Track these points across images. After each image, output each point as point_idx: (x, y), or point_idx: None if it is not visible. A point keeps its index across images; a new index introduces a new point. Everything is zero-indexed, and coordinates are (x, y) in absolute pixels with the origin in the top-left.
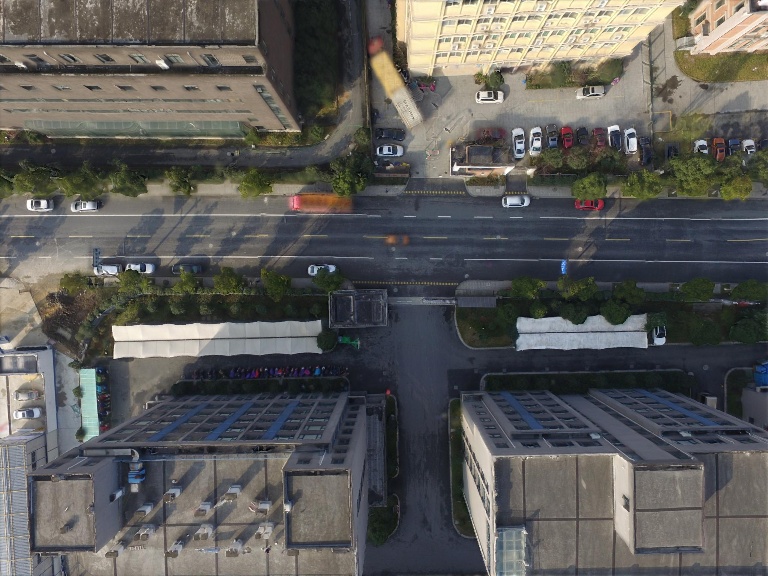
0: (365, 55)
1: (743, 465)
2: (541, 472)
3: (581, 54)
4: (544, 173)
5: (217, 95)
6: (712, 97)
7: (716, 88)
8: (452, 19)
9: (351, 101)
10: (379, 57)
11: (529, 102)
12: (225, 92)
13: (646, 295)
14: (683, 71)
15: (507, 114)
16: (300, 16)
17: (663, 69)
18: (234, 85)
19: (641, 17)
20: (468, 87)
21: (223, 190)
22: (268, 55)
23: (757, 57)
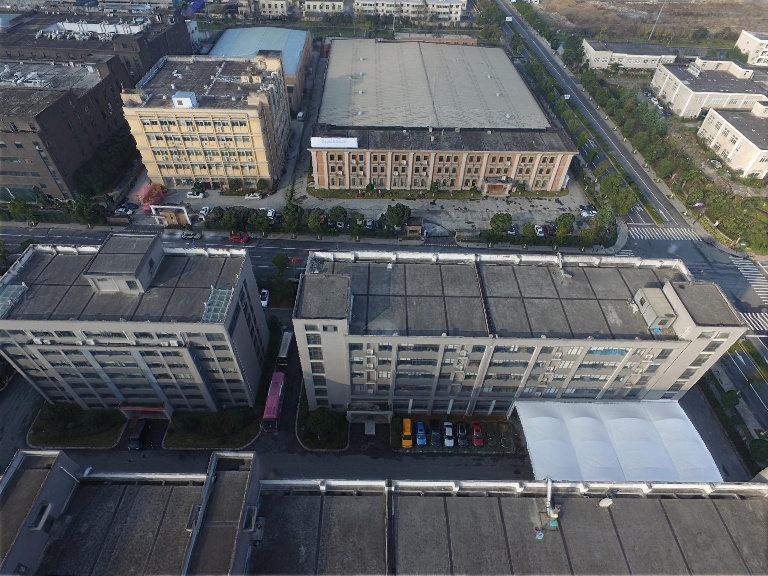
0: (132, 177)
1: (205, 262)
2: (64, 261)
3: (241, 174)
4: (210, 220)
5: (16, 153)
6: (325, 203)
7: (327, 200)
8: (151, 134)
9: (115, 195)
10: (142, 182)
11: (219, 200)
12: (20, 150)
13: (256, 275)
14: (310, 194)
15: (204, 203)
16: (96, 153)
17: (299, 193)
18: (23, 142)
19: (249, 144)
20: (186, 193)
21: (7, 224)
22: (46, 131)
23: (351, 191)
